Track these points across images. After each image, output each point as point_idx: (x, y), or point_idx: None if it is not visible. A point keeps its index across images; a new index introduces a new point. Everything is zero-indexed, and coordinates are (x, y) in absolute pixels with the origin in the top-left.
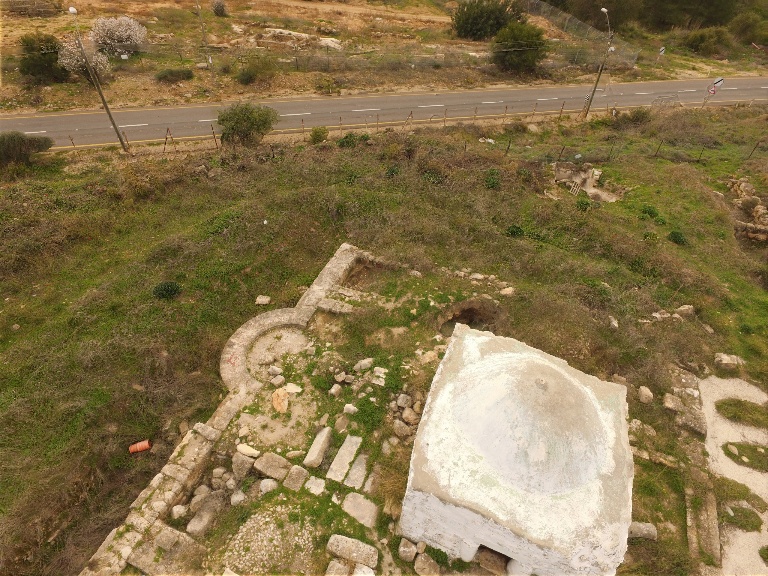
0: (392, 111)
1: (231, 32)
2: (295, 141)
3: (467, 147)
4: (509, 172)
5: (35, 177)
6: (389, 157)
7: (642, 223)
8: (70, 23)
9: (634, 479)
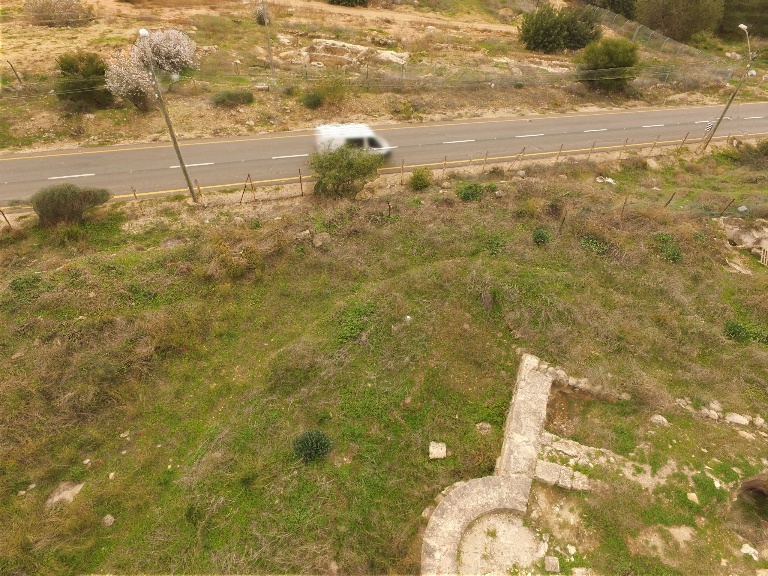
0: (489, 143)
1: (278, 43)
2: (391, 184)
3: (619, 201)
4: (686, 238)
5: (90, 239)
6: (531, 216)
7: None
8: (104, 34)
9: None
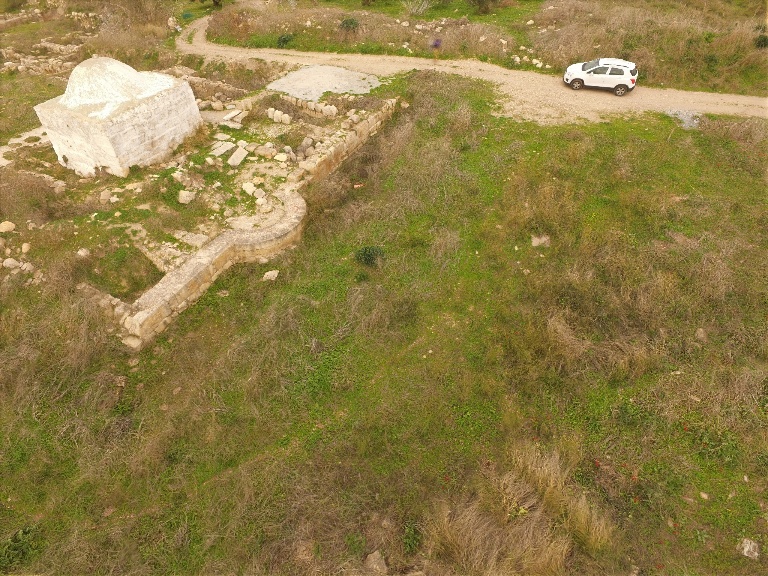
0: None
1: None
2: None
3: None
4: None
5: None
6: None
7: None
8: None
9: None
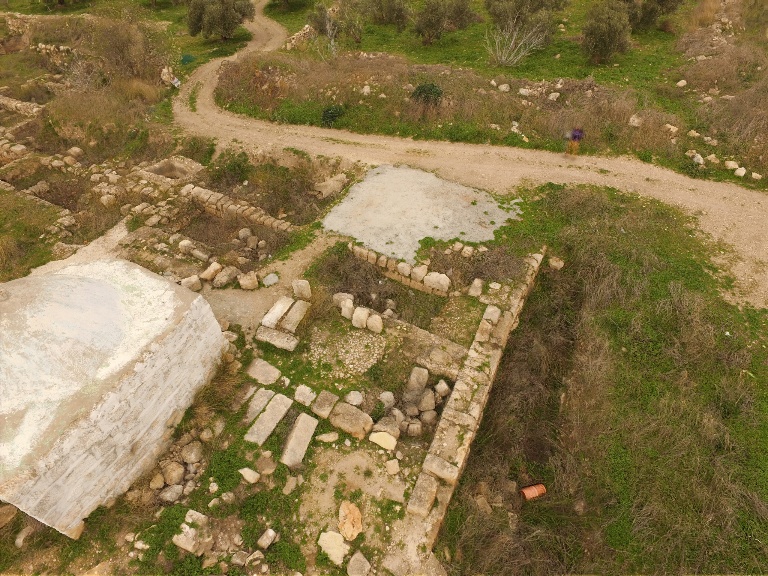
0: None
1: None
2: None
3: None
4: None
5: None
6: None
7: None
8: None
9: None
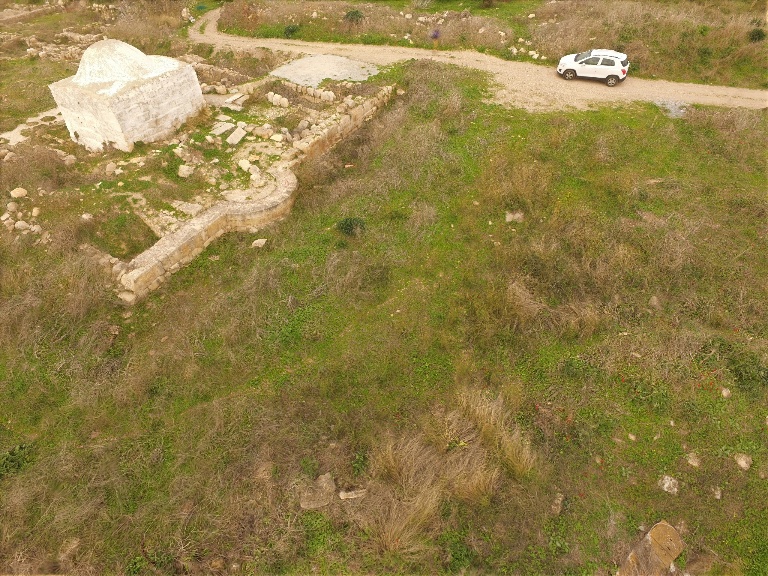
0: None
1: None
2: None
3: None
4: None
5: None
6: None
7: None
8: None
9: None
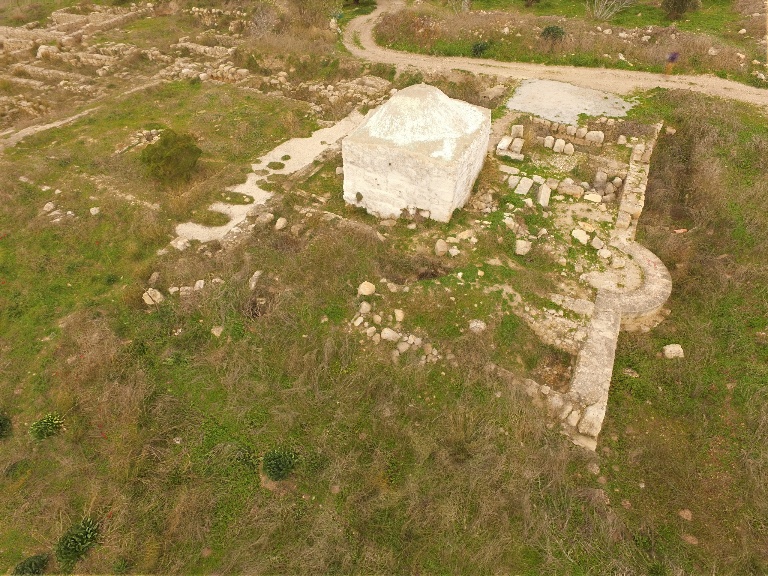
0: None
1: None
2: None
3: None
4: None
5: None
6: None
7: (4, 483)
8: None
9: (330, 190)
